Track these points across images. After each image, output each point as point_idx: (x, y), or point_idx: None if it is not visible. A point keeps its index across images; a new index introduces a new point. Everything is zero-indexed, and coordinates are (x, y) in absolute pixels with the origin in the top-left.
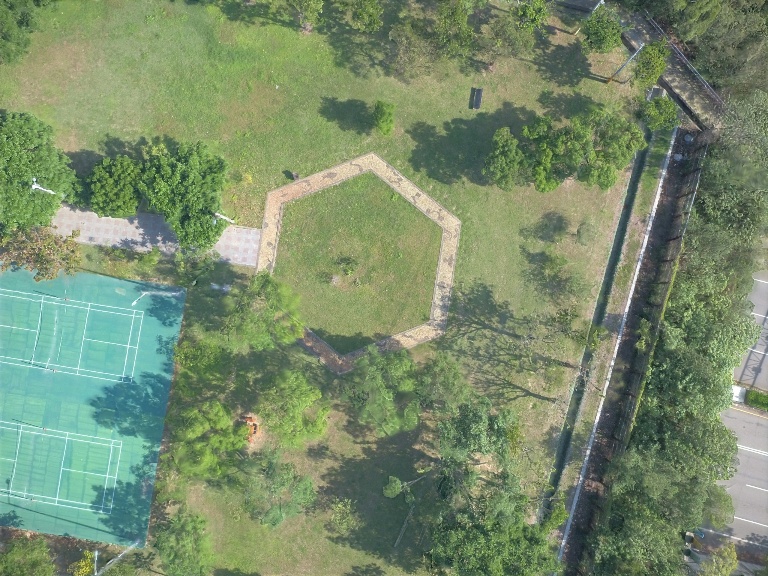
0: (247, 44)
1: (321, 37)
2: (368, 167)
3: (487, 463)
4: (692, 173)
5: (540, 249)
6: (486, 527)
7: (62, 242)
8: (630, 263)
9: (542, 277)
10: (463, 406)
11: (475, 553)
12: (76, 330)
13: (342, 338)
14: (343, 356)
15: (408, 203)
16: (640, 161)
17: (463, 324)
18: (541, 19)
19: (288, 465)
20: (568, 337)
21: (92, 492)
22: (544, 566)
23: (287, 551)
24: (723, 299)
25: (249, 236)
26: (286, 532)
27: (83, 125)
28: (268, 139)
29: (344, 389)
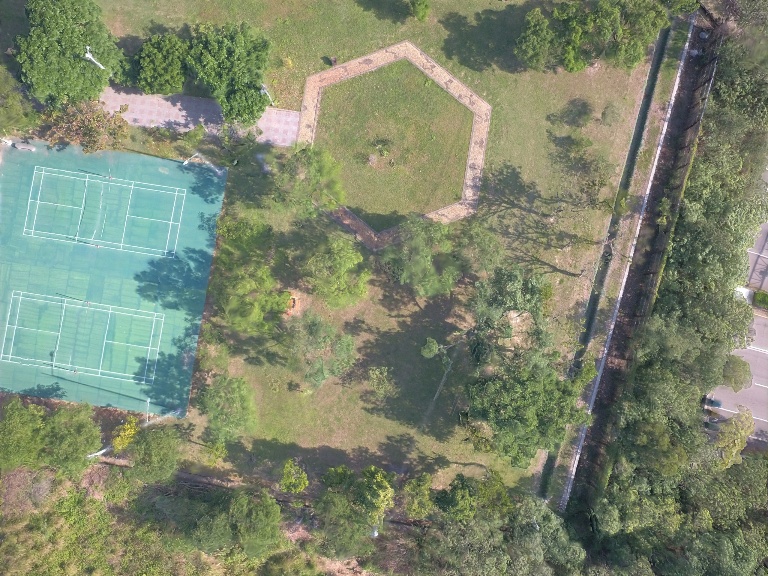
0: None
1: None
2: (402, 54)
3: (517, 336)
4: (708, 64)
5: (566, 133)
6: (522, 378)
7: (109, 118)
8: (651, 148)
9: (568, 160)
10: (498, 270)
11: (512, 403)
12: (120, 207)
13: (378, 216)
14: (379, 233)
15: (441, 89)
16: (659, 54)
17: (493, 204)
18: None
19: (325, 338)
20: (595, 208)
21: (135, 363)
22: (576, 418)
23: (324, 421)
24: (739, 179)
25: (288, 118)
26: (323, 403)
27: (128, 11)
28: (307, 27)
29: (380, 265)
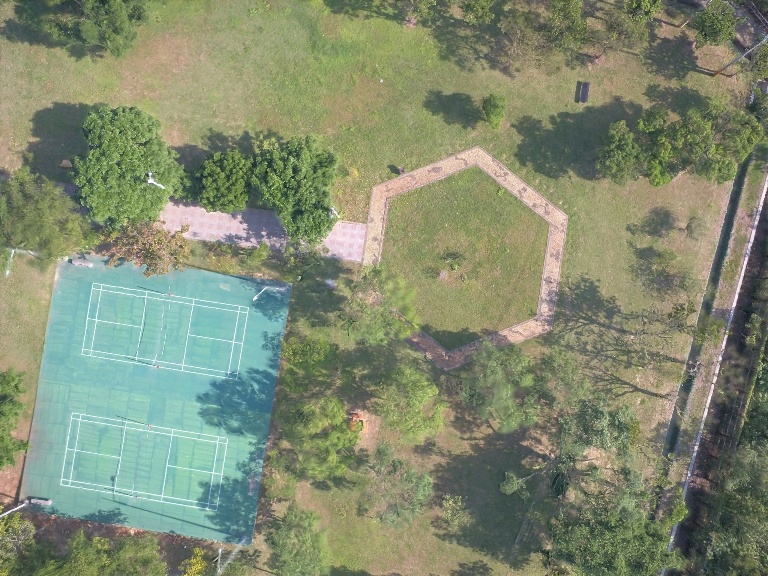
0: (351, 37)
1: (426, 30)
2: (474, 161)
3: (595, 459)
4: None
5: (647, 244)
6: (610, 523)
7: (170, 237)
8: (737, 258)
9: (650, 272)
10: (580, 402)
11: (599, 550)
12: (180, 326)
13: (449, 334)
14: (450, 352)
15: (514, 197)
16: None
17: (570, 319)
18: (654, 11)
19: (395, 462)
20: (683, 332)
21: (198, 489)
22: (666, 562)
23: (394, 548)
24: None
25: (354, 231)
26: (393, 529)
27: (186, 119)
28: (373, 133)
29: (451, 385)
